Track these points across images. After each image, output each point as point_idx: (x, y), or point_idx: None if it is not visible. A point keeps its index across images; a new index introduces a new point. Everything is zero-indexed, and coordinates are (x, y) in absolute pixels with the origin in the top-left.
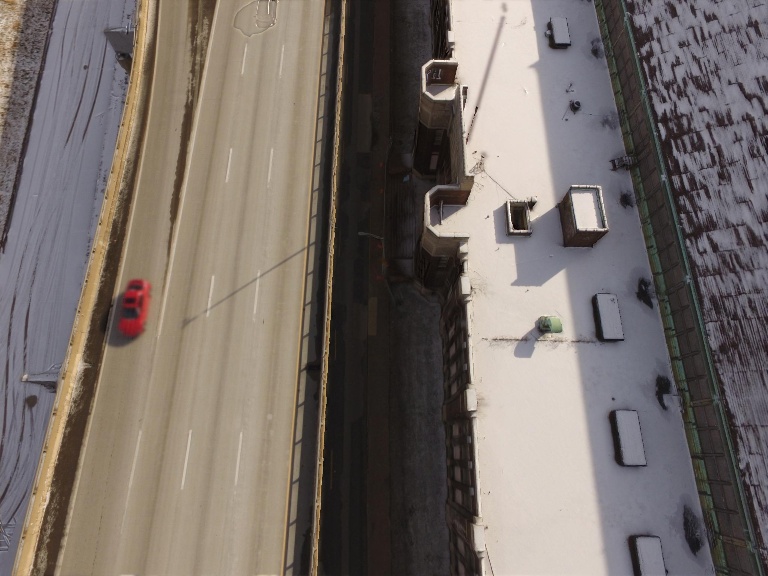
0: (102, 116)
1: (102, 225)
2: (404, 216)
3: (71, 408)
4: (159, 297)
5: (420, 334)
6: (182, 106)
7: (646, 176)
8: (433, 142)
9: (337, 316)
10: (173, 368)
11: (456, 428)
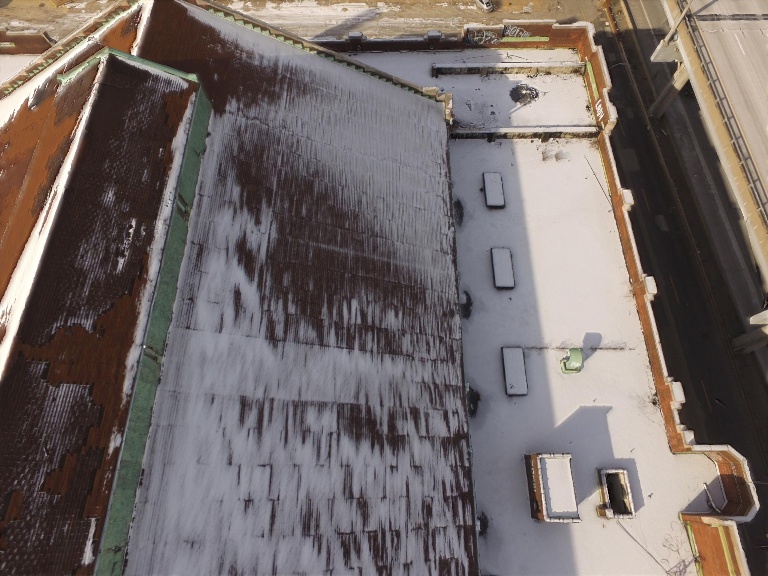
0: None
1: None
2: None
3: None
4: None
5: None
6: None
7: None
8: None
9: (715, 427)
10: None
11: None
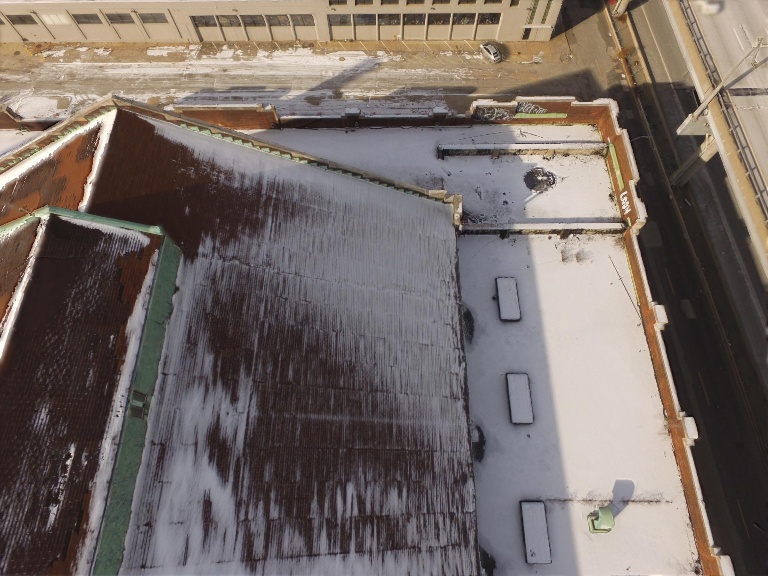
0: None
1: None
2: None
3: None
4: None
5: None
6: None
7: None
8: None
9: (754, 557)
10: None
11: None
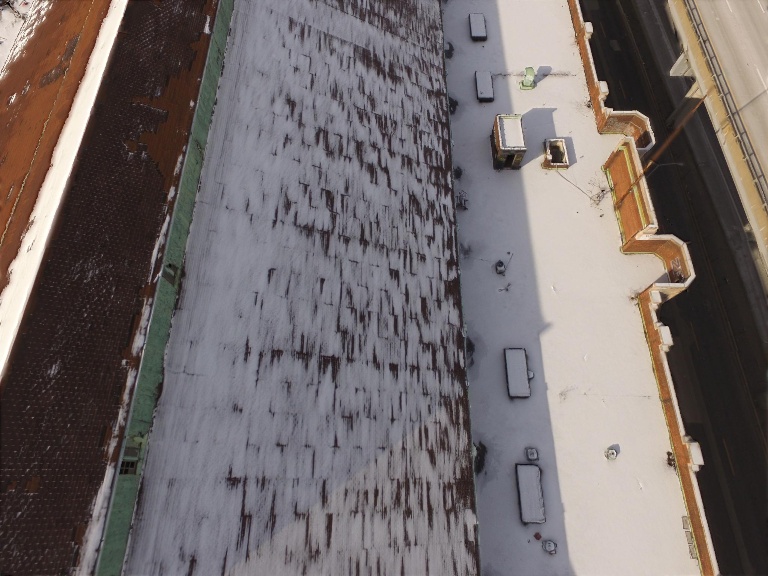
0: None
1: None
2: None
3: None
4: None
5: None
6: None
7: None
8: None
9: (649, 178)
10: None
11: None
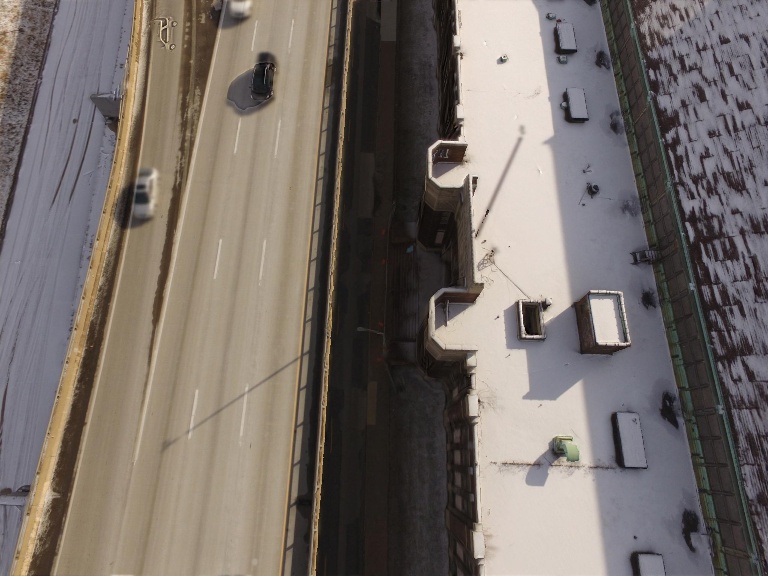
0: (90, 175)
1: (78, 330)
2: (407, 292)
3: (36, 547)
4: (137, 414)
5: (422, 425)
6: (169, 189)
7: (671, 276)
8: (439, 221)
9: (334, 402)
10: (150, 501)
11: (460, 550)
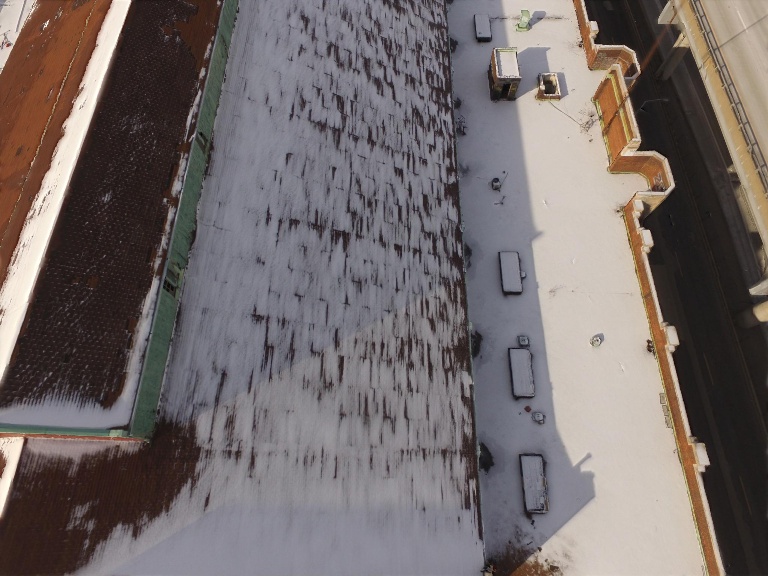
0: None
1: None
2: None
3: None
4: None
5: None
6: None
7: None
8: None
9: None
10: None
11: None
